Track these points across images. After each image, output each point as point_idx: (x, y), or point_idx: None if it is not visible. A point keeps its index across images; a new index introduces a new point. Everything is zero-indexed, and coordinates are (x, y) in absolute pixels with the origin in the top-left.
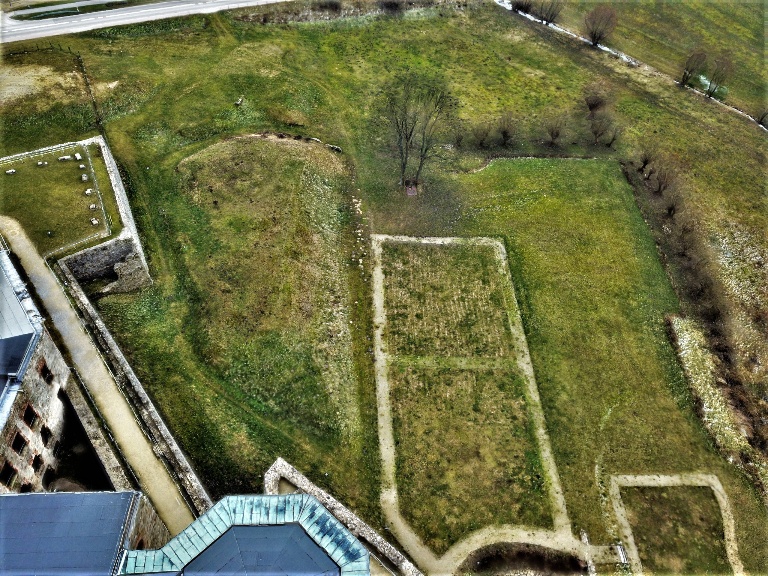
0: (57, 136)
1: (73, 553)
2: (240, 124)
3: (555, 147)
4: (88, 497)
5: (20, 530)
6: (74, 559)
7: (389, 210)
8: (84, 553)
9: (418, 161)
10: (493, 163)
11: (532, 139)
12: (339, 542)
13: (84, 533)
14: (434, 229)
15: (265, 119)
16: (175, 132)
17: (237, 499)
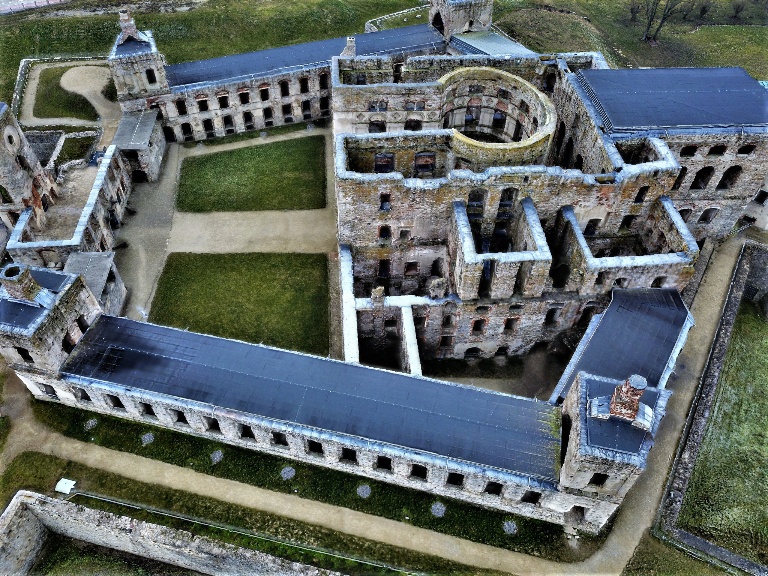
0: (408, 7)
1: None
2: (512, 5)
3: (738, 19)
4: None
5: (703, 75)
6: None
7: (643, 54)
8: None
9: (644, 29)
10: (700, 28)
11: (719, 15)
12: None
13: (733, 75)
14: (680, 64)
15: (526, 3)
16: None
17: None
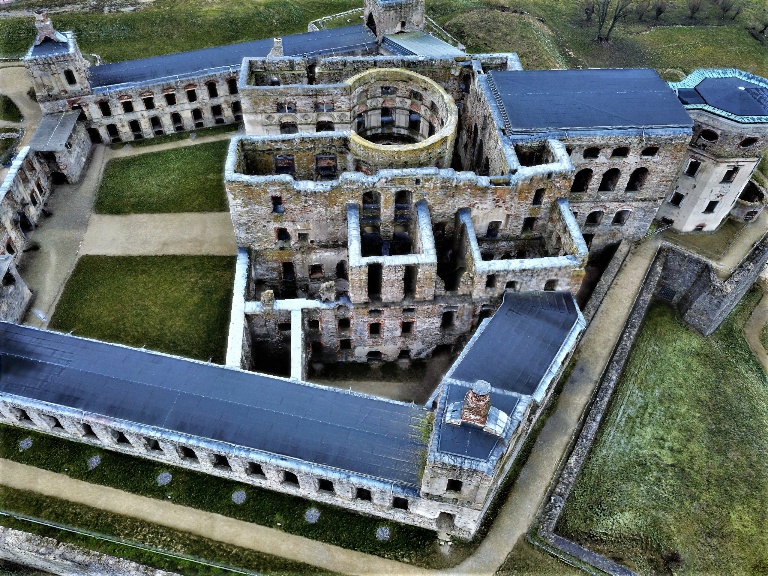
0: (357, 7)
1: (645, 81)
2: (466, 6)
3: (694, 20)
4: (633, 69)
5: (613, 76)
6: (647, 82)
7: (594, 55)
8: (650, 81)
9: None
10: (654, 29)
11: (675, 16)
12: (760, 80)
13: None
14: (631, 65)
15: (481, 3)
16: (428, 8)
17: (702, 70)
